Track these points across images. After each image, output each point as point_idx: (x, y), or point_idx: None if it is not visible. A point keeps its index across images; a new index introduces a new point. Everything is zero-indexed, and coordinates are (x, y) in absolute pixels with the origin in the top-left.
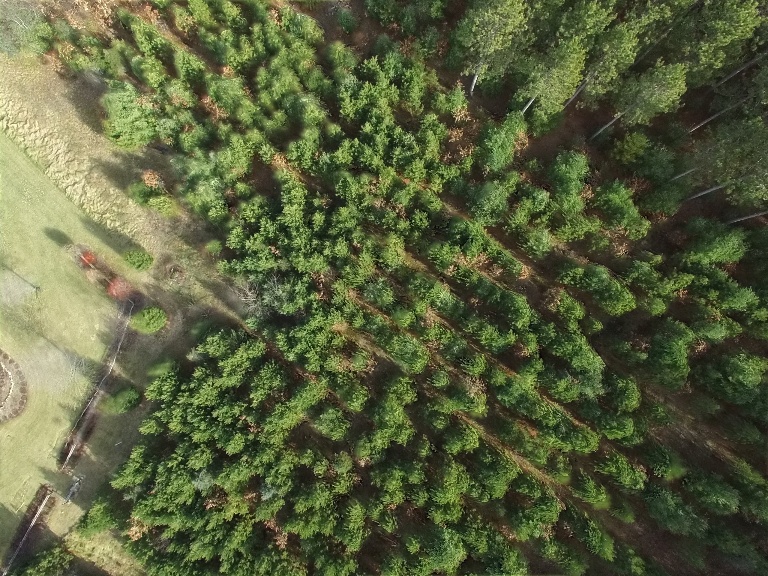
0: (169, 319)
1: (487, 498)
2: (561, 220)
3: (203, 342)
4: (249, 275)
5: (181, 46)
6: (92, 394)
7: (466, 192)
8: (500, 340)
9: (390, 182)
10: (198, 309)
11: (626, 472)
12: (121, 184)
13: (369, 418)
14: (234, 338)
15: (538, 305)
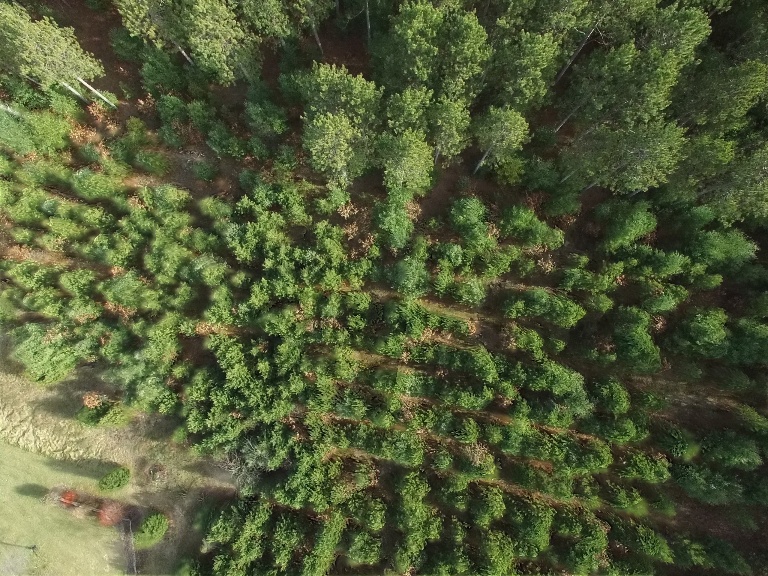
0: (170, 518)
1: (536, 552)
2: (482, 264)
3: (210, 532)
4: (224, 447)
5: (65, 260)
6: None
7: (386, 278)
8: (479, 401)
9: (312, 302)
10: (192, 496)
11: (648, 468)
12: (67, 413)
13: (395, 527)
14: (236, 515)
15: (499, 345)
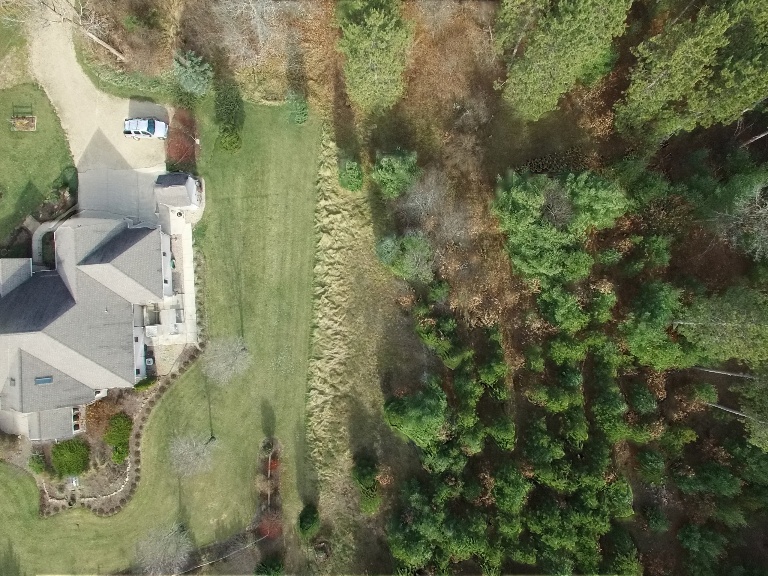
0: None
1: None
2: None
3: None
4: None
5: (509, 380)
6: (168, 574)
7: None
8: None
9: None
10: None
11: None
12: (354, 431)
13: None
14: None
15: None
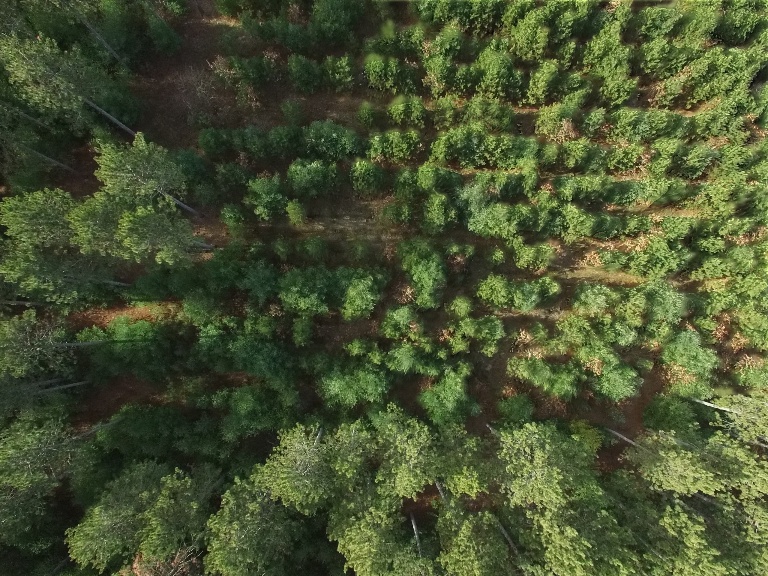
0: None
1: (494, 44)
2: None
3: None
4: None
5: None
6: None
7: None
8: (575, 184)
9: (764, 259)
10: None
11: (394, 144)
12: None
13: None
14: None
15: None
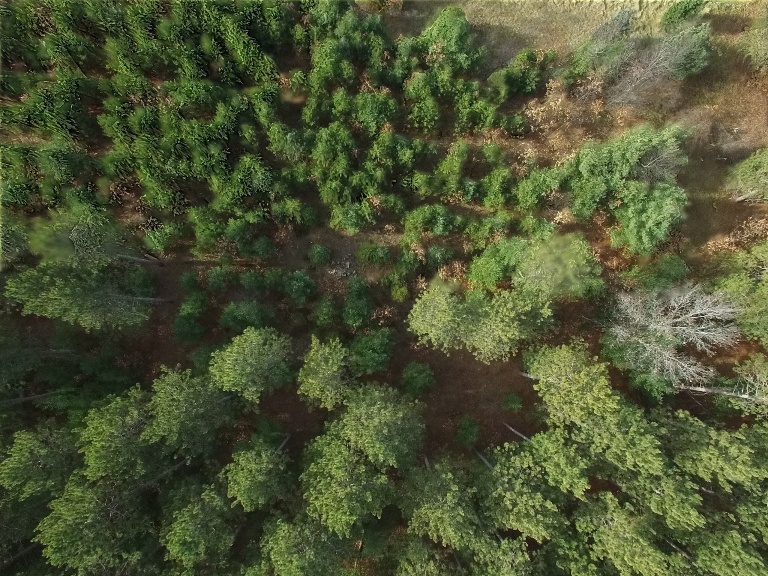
0: None
1: None
2: None
3: None
4: None
5: None
6: None
7: (101, 161)
8: None
9: None
10: None
11: None
12: None
13: None
14: None
15: None
